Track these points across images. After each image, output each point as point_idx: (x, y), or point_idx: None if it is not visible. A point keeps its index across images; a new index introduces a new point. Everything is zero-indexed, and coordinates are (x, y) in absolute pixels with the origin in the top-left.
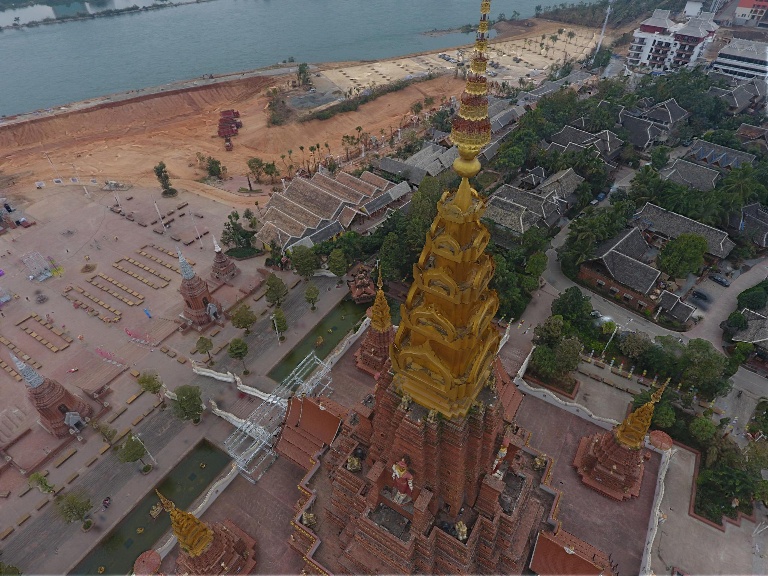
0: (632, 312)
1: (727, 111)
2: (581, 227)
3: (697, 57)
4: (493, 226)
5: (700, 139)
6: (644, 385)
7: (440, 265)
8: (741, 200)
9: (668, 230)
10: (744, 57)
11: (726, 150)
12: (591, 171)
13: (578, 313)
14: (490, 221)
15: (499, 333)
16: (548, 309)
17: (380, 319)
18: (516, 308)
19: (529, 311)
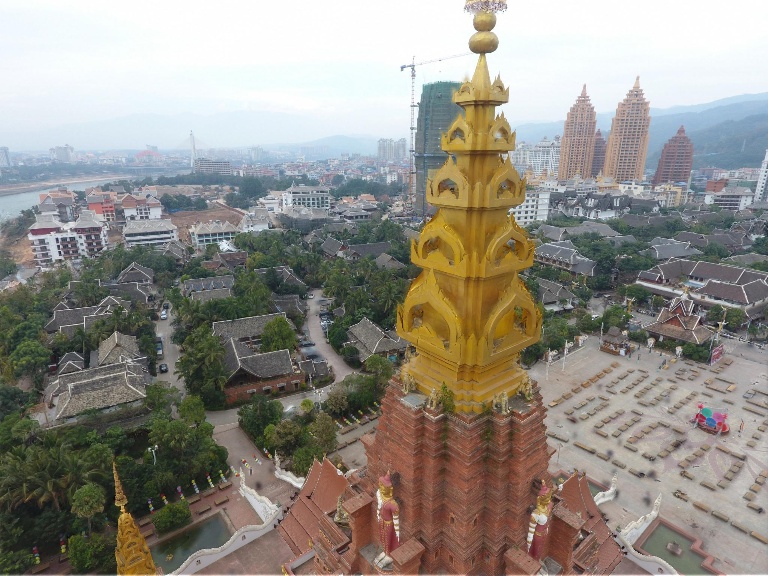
0: (294, 395)
1: (176, 263)
2: (200, 354)
3: (105, 243)
4: (101, 413)
5: (186, 280)
6: (367, 423)
7: (479, 179)
8: (268, 291)
9: (246, 333)
10: (146, 232)
11: (211, 279)
12: (136, 327)
13: (278, 413)
14: (91, 411)
15: (231, 495)
16: (240, 441)
17: (144, 567)
18: (222, 457)
19: (228, 456)
